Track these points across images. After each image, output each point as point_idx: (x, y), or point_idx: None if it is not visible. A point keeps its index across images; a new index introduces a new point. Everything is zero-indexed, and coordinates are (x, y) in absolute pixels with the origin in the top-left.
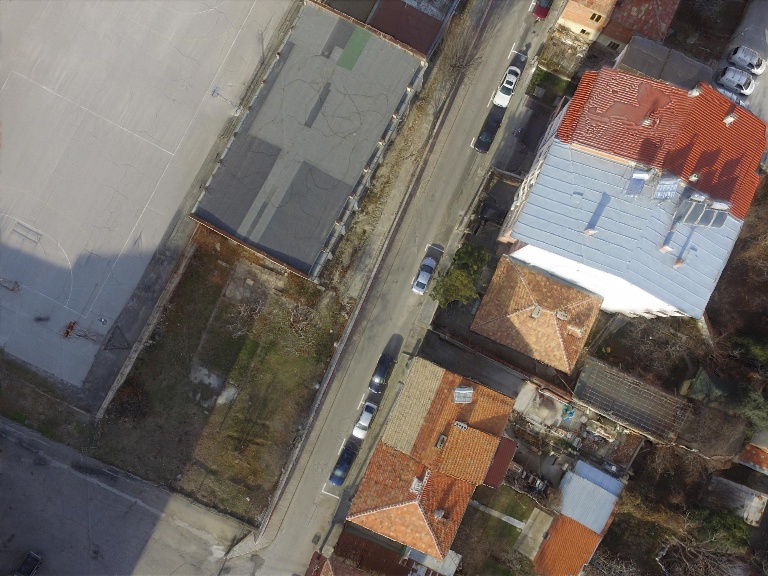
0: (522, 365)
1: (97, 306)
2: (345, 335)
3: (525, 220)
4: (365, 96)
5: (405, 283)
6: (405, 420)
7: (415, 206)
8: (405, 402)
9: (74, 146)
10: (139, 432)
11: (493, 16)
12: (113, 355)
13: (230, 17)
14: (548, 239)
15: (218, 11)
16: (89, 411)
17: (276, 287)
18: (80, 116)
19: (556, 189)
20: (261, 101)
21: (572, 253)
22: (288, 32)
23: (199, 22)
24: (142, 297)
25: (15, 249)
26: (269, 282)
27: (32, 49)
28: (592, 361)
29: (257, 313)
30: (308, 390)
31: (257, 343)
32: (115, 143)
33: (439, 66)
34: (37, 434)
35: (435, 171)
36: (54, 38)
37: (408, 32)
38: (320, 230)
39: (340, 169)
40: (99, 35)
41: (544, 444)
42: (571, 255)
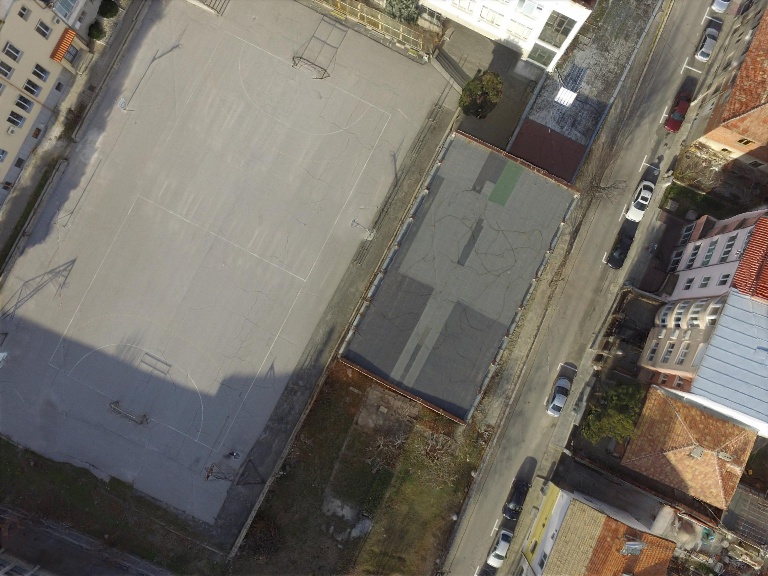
0: (660, 488)
1: (229, 439)
2: (484, 465)
3: (705, 374)
4: (519, 232)
5: (537, 403)
6: (564, 568)
7: (547, 324)
8: (562, 548)
9: (203, 273)
10: (271, 568)
11: (624, 128)
12: (246, 490)
13: (361, 138)
14: (732, 396)
15: (349, 132)
16: (222, 550)
17: (410, 414)
18: (209, 242)
19: (737, 342)
20: (411, 238)
21: (761, 413)
22: (435, 164)
23: (329, 143)
24: (275, 429)
25: (143, 381)
26: (403, 409)
27: (158, 173)
28: (739, 488)
29: (395, 446)
30: (445, 521)
31: (391, 473)
32: (245, 269)
33: (574, 184)
34: (166, 573)
35: (566, 287)
36: (181, 161)
37: (552, 157)
38: (476, 373)
39: (495, 308)
40: (227, 158)
41: (684, 569)
42: (760, 415)
